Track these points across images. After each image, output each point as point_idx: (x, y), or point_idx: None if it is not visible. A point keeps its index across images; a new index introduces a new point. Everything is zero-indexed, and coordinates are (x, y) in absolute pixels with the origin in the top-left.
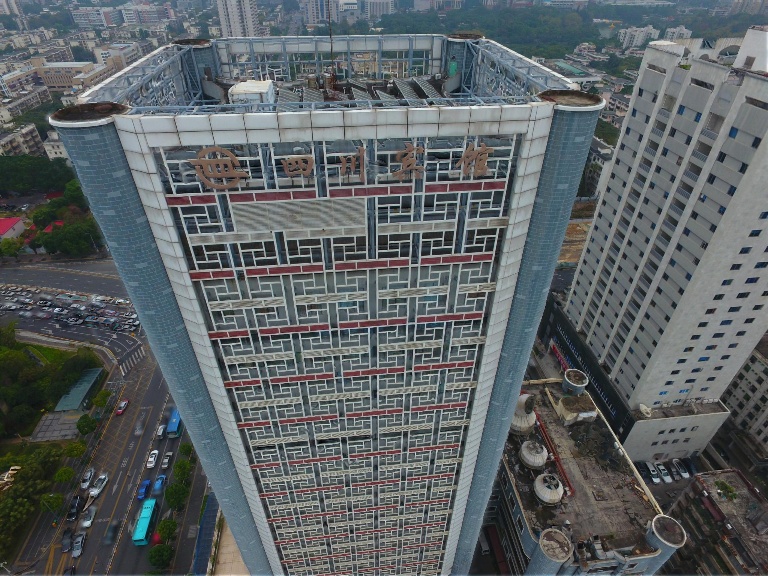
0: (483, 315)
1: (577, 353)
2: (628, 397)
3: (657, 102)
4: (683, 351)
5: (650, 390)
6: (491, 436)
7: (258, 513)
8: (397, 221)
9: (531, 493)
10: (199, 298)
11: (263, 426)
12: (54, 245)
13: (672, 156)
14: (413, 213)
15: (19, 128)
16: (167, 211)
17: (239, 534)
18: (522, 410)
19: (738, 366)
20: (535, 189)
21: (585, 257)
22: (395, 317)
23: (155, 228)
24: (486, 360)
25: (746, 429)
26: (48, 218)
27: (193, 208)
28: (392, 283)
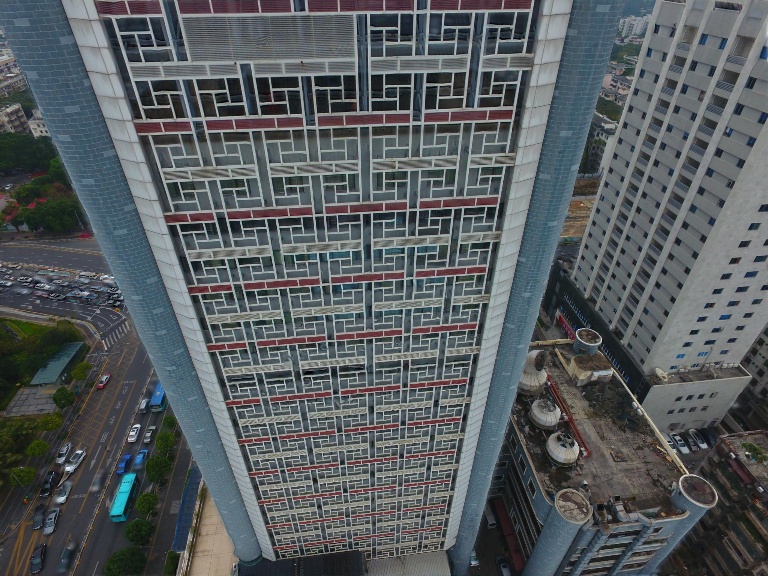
0: (499, 200)
1: (586, 321)
2: (642, 362)
3: (676, 36)
4: (704, 307)
5: (667, 352)
6: (504, 369)
7: (237, 464)
8: (395, 55)
9: (543, 454)
10: (150, 164)
11: (238, 349)
12: (36, 221)
13: (693, 92)
14: (415, 42)
15: (4, 107)
16: (98, 22)
17: (217, 491)
18: (532, 366)
19: (761, 326)
20: (568, 15)
21: (594, 218)
22: (393, 200)
23: (86, 54)
24: (501, 265)
25: (767, 397)
26: (31, 195)
27: (132, 20)
28: (389, 149)
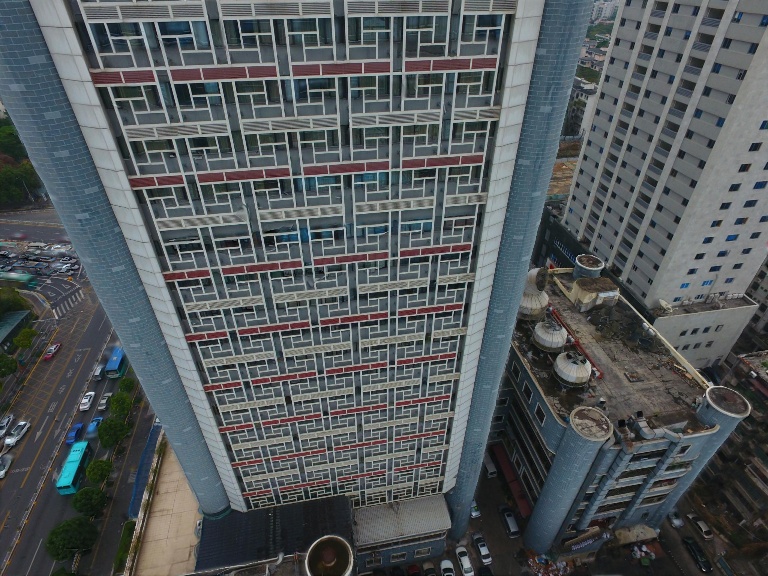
0: None
1: None
2: (644, 295)
3: None
4: (710, 226)
5: (671, 281)
6: (515, 231)
7: (188, 373)
8: None
9: (551, 378)
10: None
11: (172, 186)
12: None
13: None
14: None
15: None
16: None
17: (165, 413)
18: (533, 285)
19: (767, 248)
20: None
21: (585, 151)
22: None
23: None
24: (515, 56)
25: None
26: None
27: None
28: None
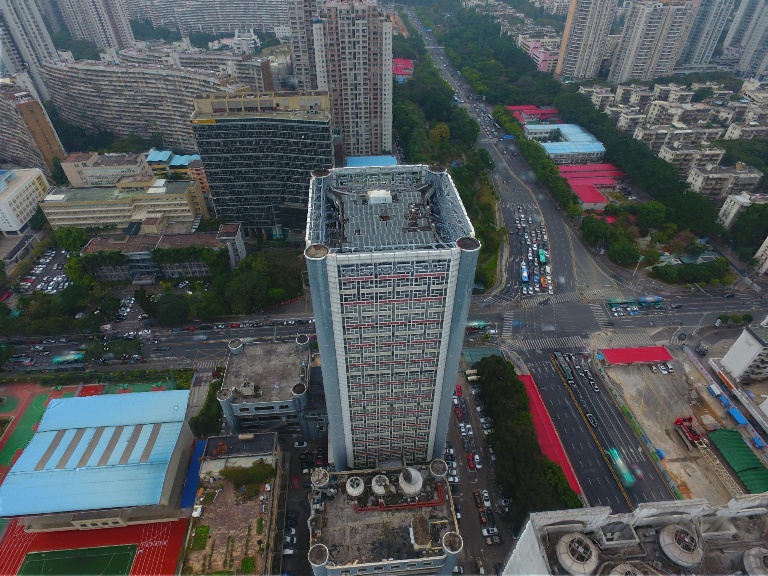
0: None
1: None
2: None
3: None
4: None
5: None
6: None
7: None
8: None
9: None
10: None
11: None
12: (583, 226)
13: None
14: None
15: (709, 149)
16: None
17: None
18: None
19: None
20: None
21: None
22: None
23: None
24: None
25: None
26: (611, 212)
27: None
28: None
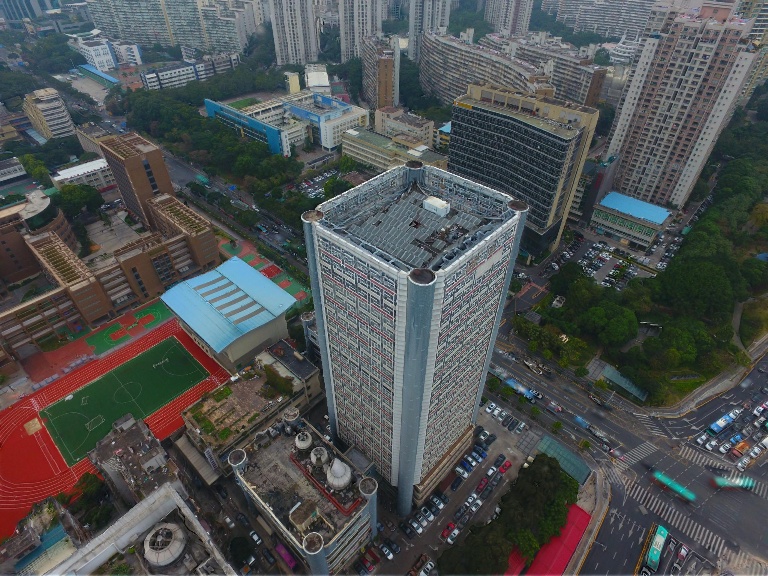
0: None
1: None
2: None
3: None
4: None
5: None
6: None
7: None
8: None
9: None
10: None
11: None
12: None
13: None
14: None
15: None
16: None
17: None
18: None
19: None
20: None
21: None
22: None
23: None
24: None
25: None
26: None
27: None
28: None
